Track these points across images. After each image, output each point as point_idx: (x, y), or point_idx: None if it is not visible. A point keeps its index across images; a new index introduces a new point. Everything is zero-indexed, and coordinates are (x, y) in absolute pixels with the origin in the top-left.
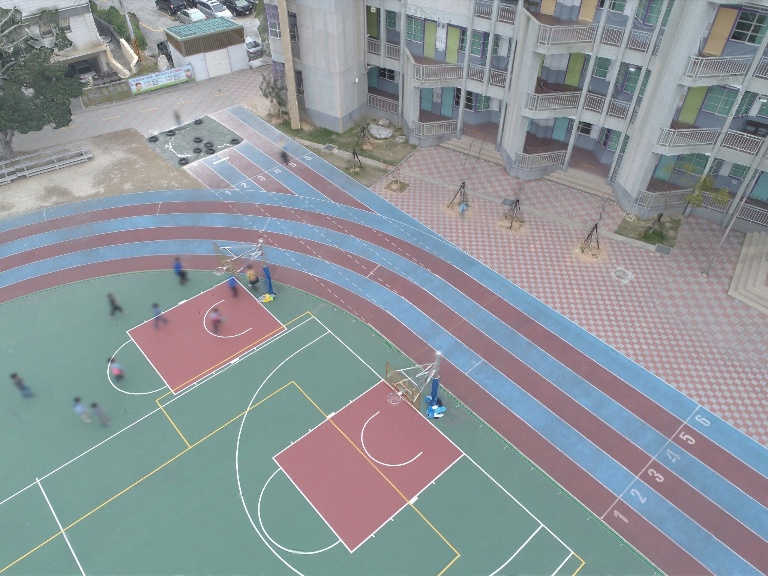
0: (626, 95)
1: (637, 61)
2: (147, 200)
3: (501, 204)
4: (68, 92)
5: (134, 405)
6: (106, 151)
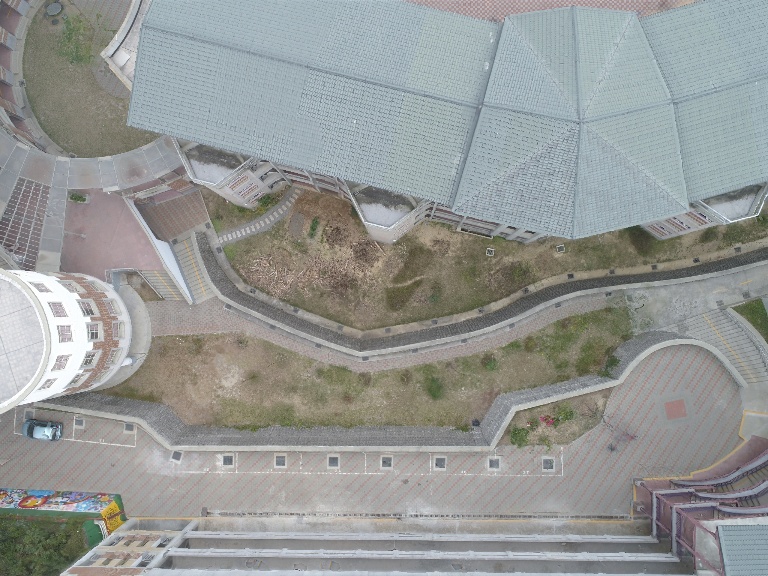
0: None
1: None
2: None
3: None
4: None
5: None
6: None
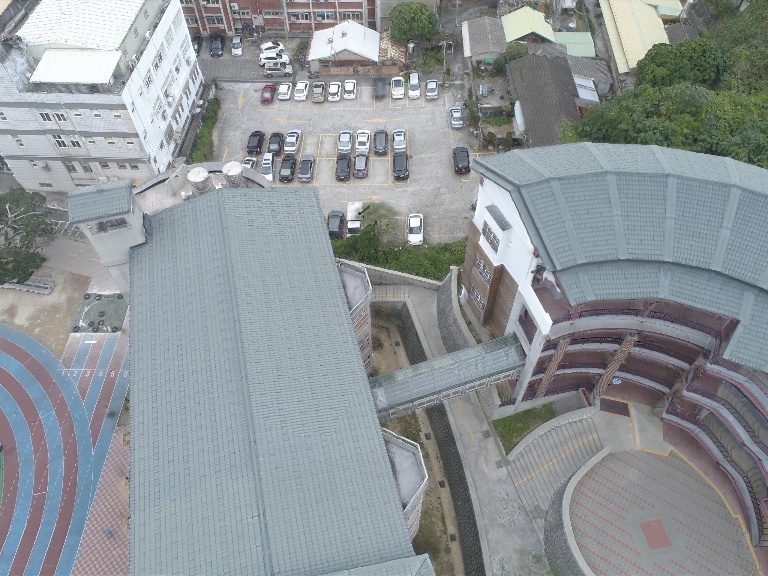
0: None
1: None
2: (31, 350)
3: None
4: (30, 265)
5: None
6: (62, 290)
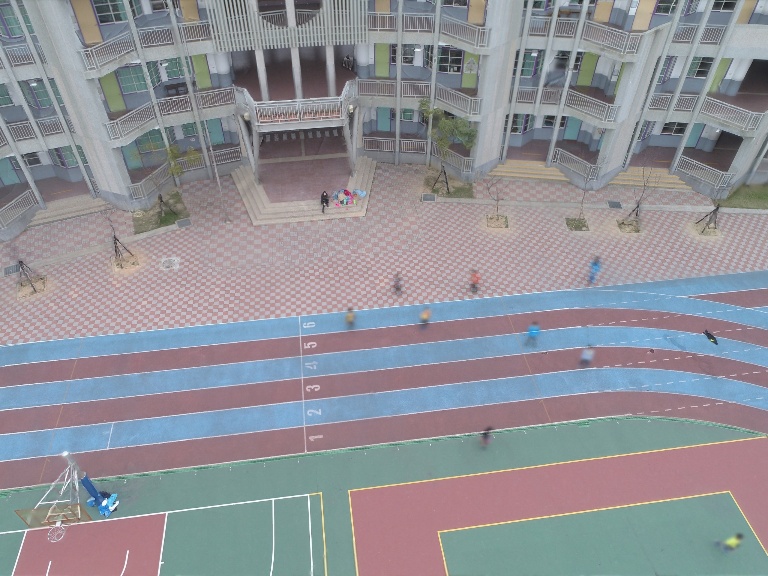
0: (47, 110)
1: (32, 75)
2: None
3: (5, 276)
4: None
5: None
6: None
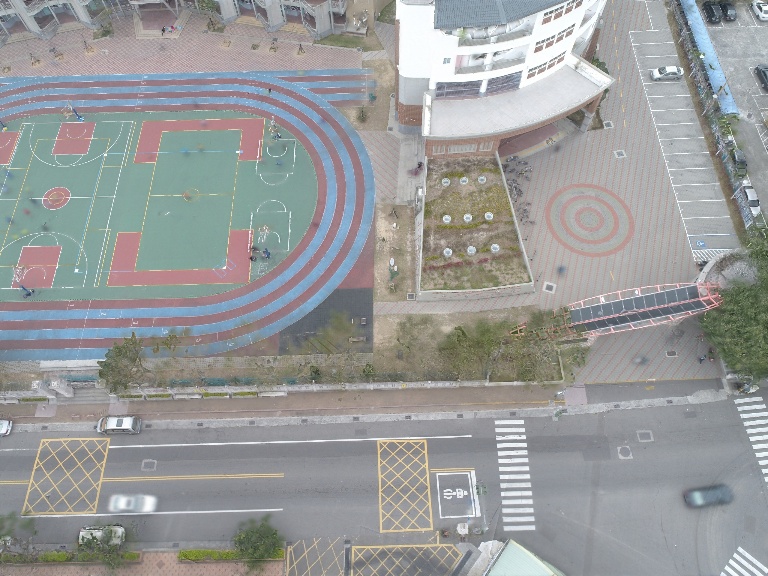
0: None
1: None
2: None
3: (50, 53)
4: None
5: (1, 174)
6: None
